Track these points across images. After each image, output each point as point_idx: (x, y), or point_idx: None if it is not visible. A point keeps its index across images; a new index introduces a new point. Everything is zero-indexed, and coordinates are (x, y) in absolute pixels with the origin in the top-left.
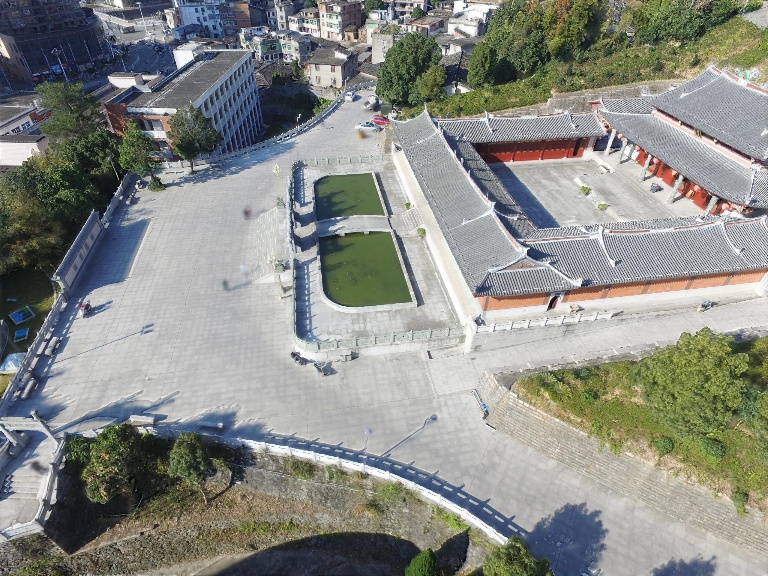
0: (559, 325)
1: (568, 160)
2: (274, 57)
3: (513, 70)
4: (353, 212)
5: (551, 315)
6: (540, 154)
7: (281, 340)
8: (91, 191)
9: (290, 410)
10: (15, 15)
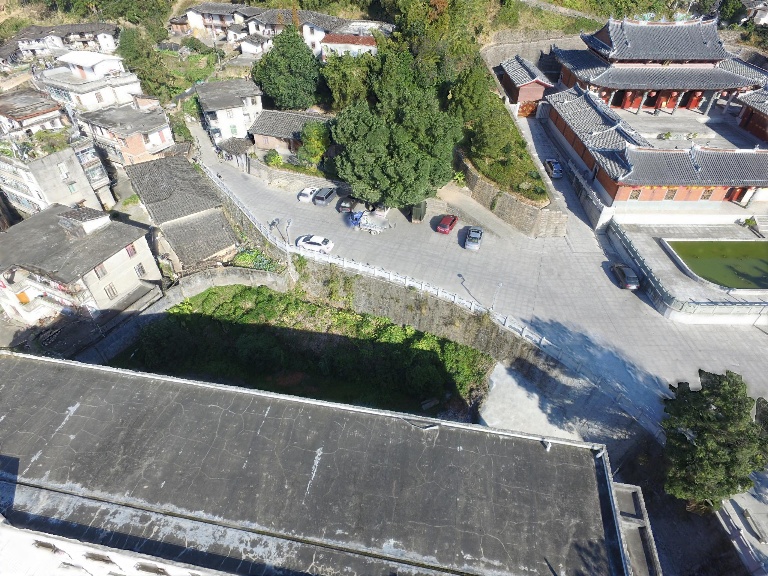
0: None
1: None
2: None
3: (450, 89)
4: None
5: None
6: None
7: None
8: None
9: None
10: None
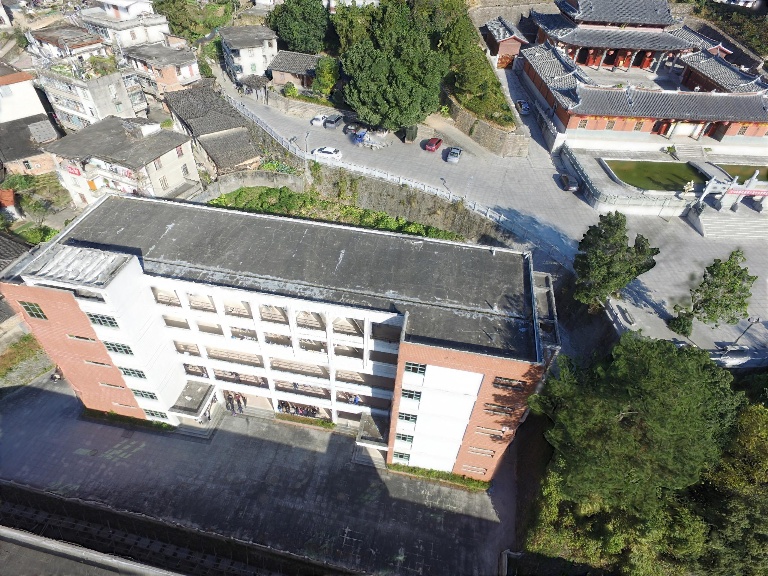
0: None
1: None
2: None
3: None
4: (686, 177)
5: None
6: None
7: None
8: None
9: None
10: None
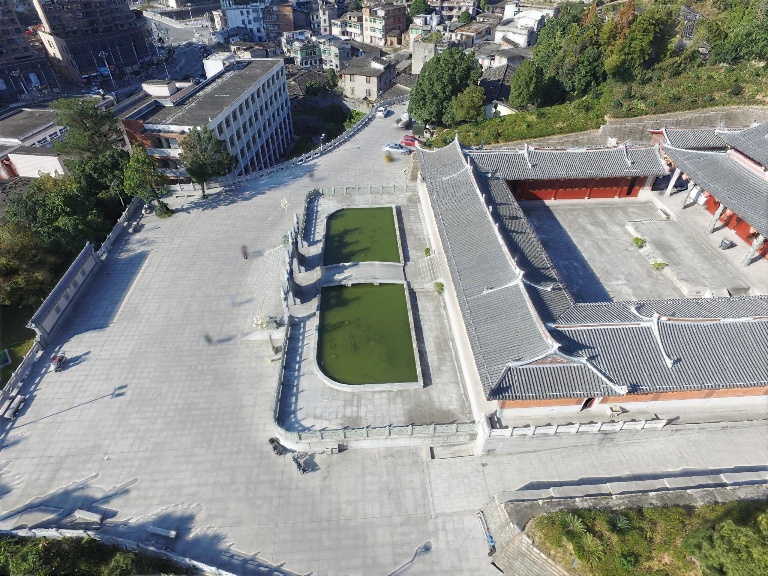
0: (595, 433)
1: (620, 200)
2: (314, 62)
3: (562, 90)
4: (365, 256)
5: (585, 417)
6: (587, 192)
7: (262, 418)
8: (94, 217)
9: (257, 518)
10: (68, 18)
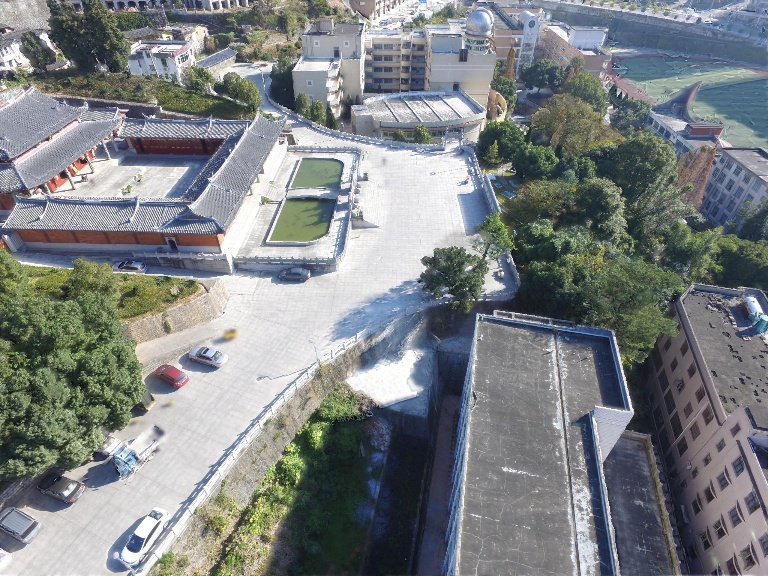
0: None
1: None
2: None
3: None
4: (307, 207)
5: None
6: None
7: None
8: None
9: None
10: None
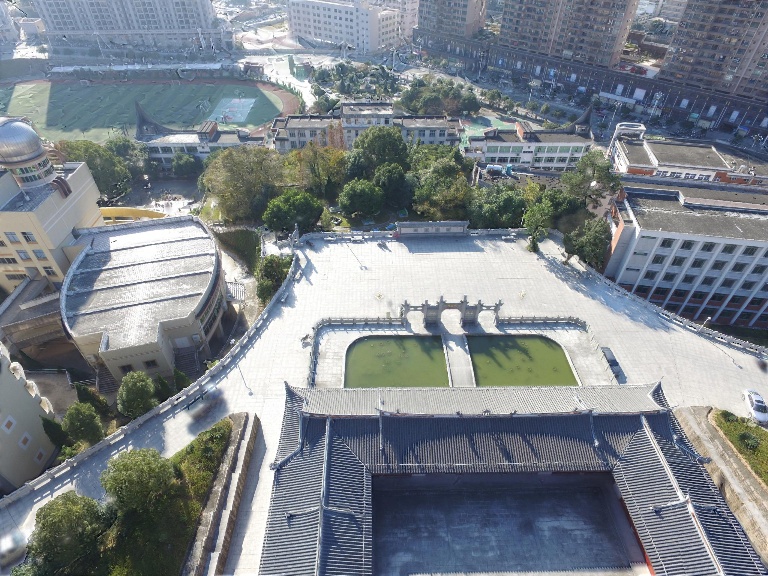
0: None
1: None
2: None
3: None
4: (488, 363)
5: None
6: None
7: None
8: (507, 217)
9: (284, 327)
10: None
